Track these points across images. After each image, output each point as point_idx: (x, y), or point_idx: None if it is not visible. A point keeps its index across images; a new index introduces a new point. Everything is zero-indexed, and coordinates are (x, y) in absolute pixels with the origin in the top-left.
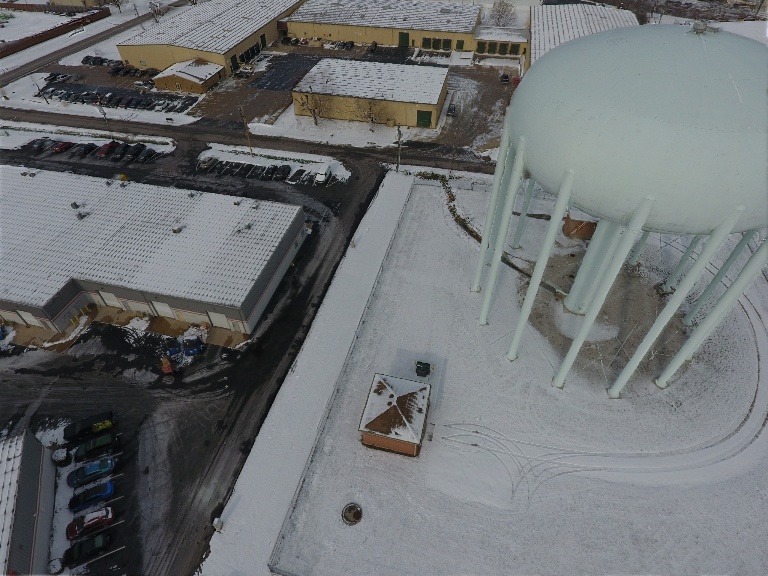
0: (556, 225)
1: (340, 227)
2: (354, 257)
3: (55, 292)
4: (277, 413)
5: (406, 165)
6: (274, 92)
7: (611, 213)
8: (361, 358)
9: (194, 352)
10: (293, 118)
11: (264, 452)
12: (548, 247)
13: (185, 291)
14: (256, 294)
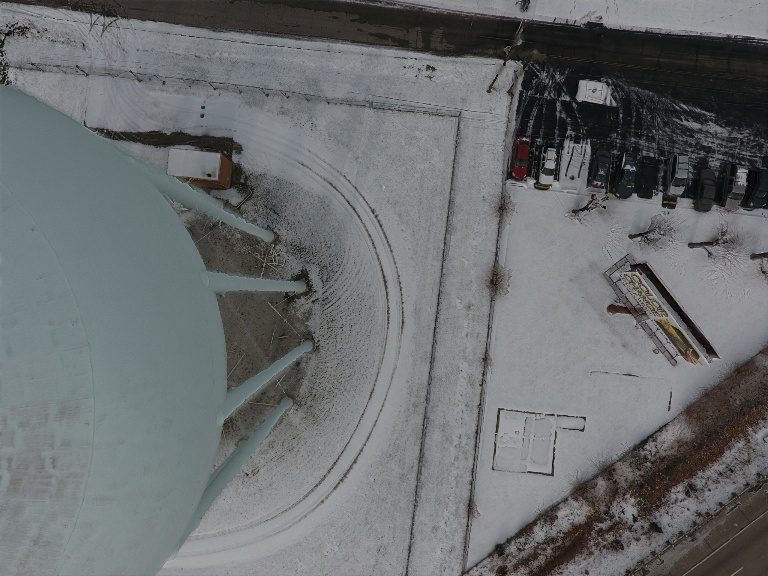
0: None
1: None
2: None
3: None
4: None
5: None
6: None
7: None
8: None
9: None
10: None
11: None
12: None
13: None
14: None
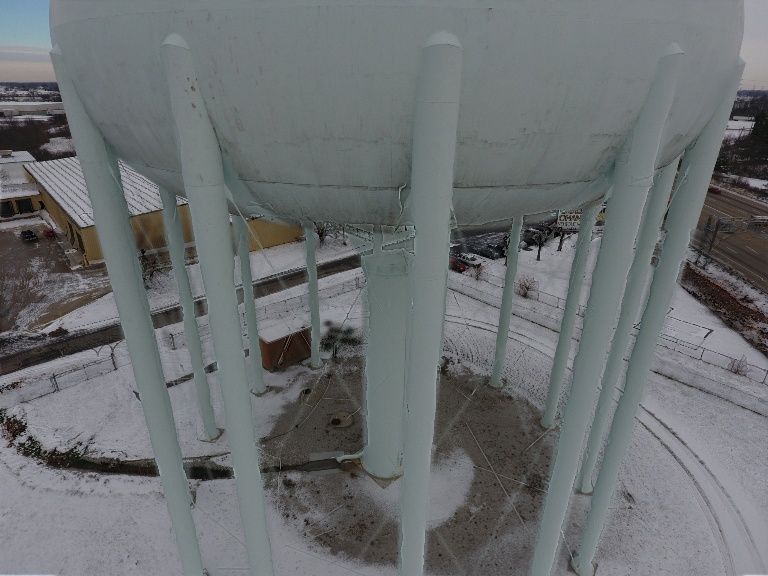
0: (442, 275)
1: None
2: None
3: None
4: None
5: None
6: None
7: (570, 161)
8: None
9: None
10: None
11: None
12: (434, 359)
13: None
14: None
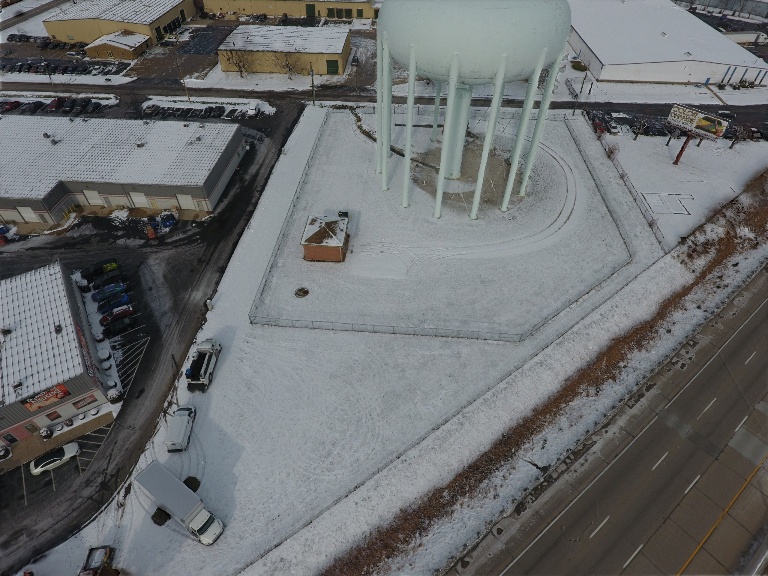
0: (412, 87)
1: (272, 144)
2: (286, 161)
3: (49, 190)
4: (241, 250)
5: (321, 101)
6: (200, 56)
7: (440, 71)
8: (298, 217)
9: (170, 224)
10: (221, 74)
11: (235, 270)
12: (411, 105)
13: (157, 180)
14: (213, 181)
